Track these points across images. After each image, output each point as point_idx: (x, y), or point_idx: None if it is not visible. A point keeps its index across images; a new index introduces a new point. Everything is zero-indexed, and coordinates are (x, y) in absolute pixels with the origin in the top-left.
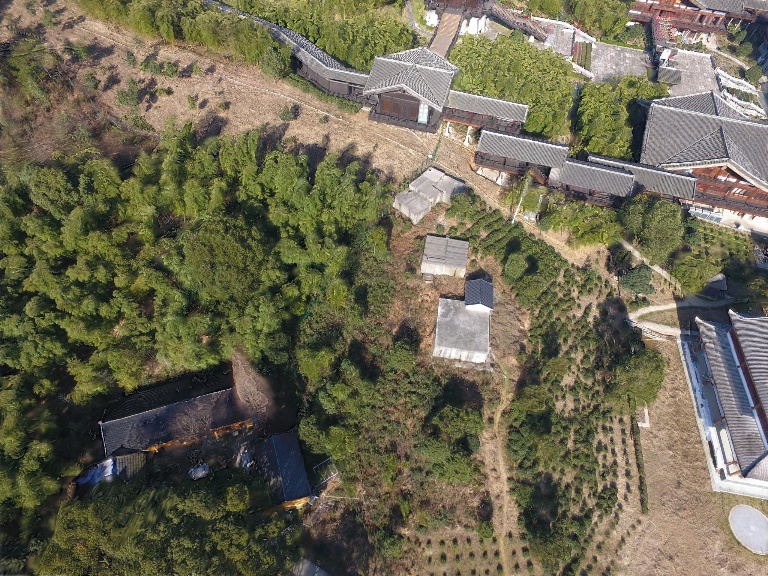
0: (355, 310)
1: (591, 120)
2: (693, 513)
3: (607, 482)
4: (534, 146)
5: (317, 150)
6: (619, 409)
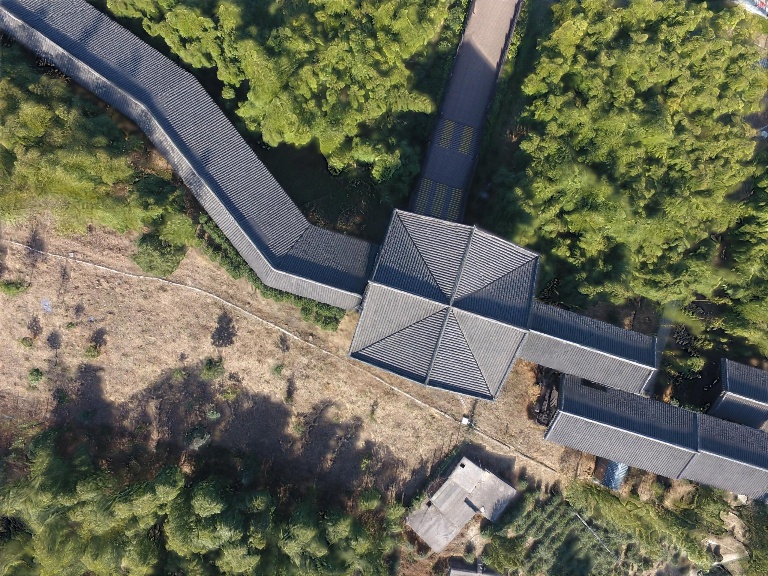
0: None
1: (757, 275)
2: None
3: None
4: (642, 442)
5: (278, 404)
6: None
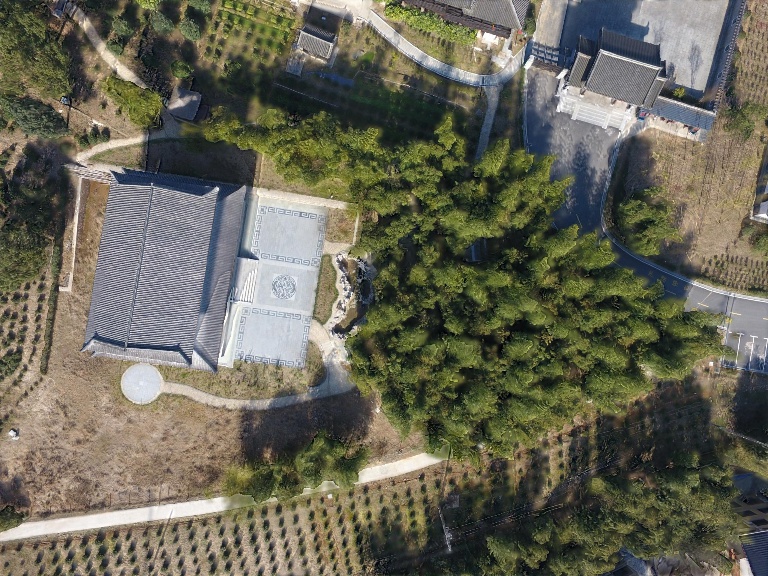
0: None
1: None
2: (90, 372)
3: (13, 347)
4: None
5: None
6: (41, 274)
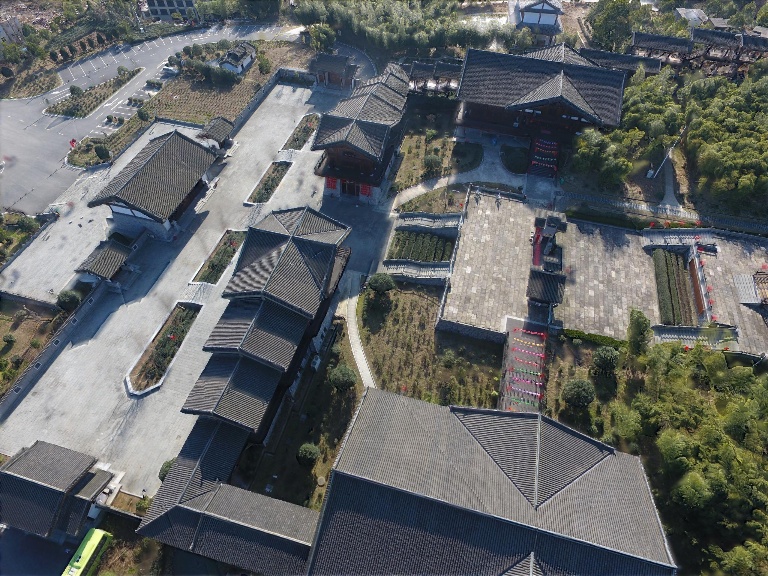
0: (750, 6)
1: None
2: None
3: None
4: None
5: None
6: None
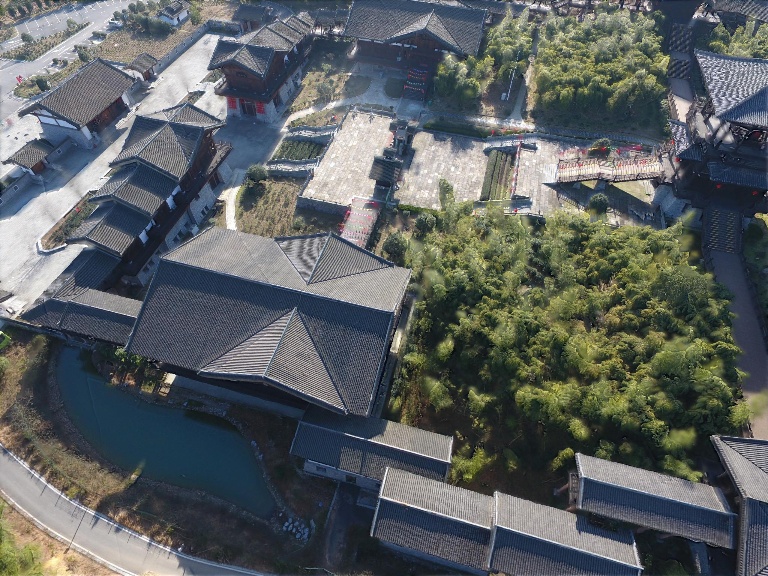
0: None
1: None
2: None
3: None
4: None
5: None
6: None
